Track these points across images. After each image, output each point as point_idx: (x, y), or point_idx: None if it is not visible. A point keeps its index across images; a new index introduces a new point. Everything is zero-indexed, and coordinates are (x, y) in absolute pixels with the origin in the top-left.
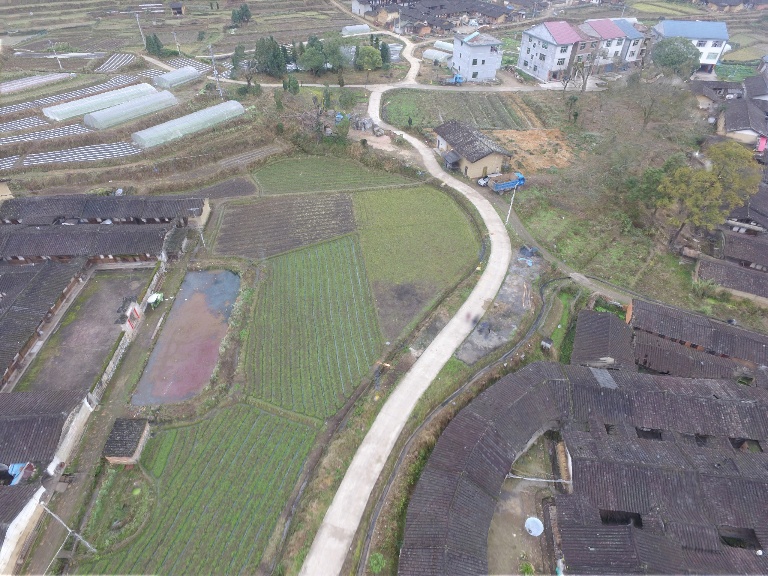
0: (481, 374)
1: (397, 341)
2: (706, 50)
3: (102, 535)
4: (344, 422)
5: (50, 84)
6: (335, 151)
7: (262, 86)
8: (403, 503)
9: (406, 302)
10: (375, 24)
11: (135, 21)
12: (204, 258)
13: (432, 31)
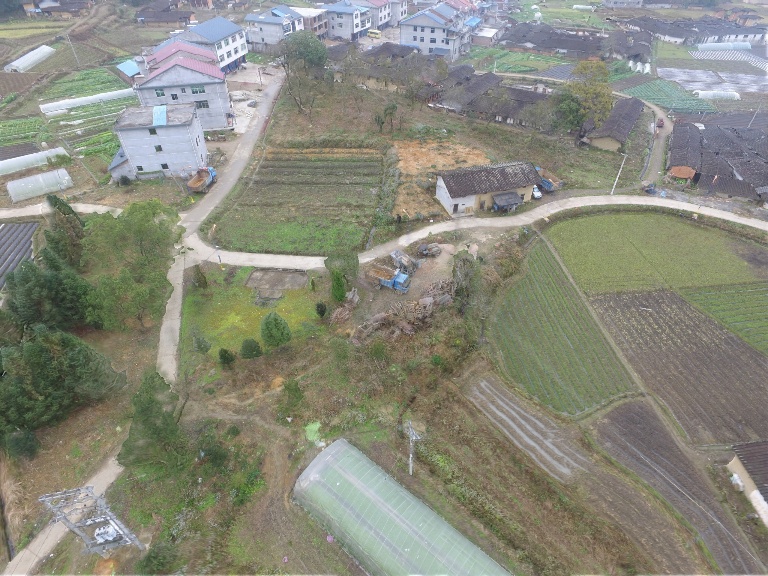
0: None
1: None
2: (237, 44)
3: None
4: None
5: None
6: None
7: None
8: None
9: None
10: None
11: None
12: None
13: None
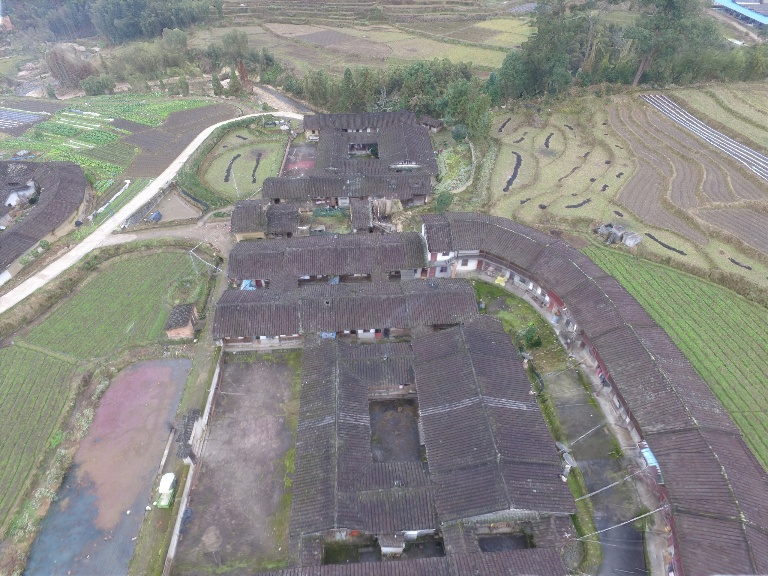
0: None
1: None
2: None
3: (194, 279)
4: None
5: None
6: None
7: None
8: None
9: None
10: None
11: None
12: None
13: None
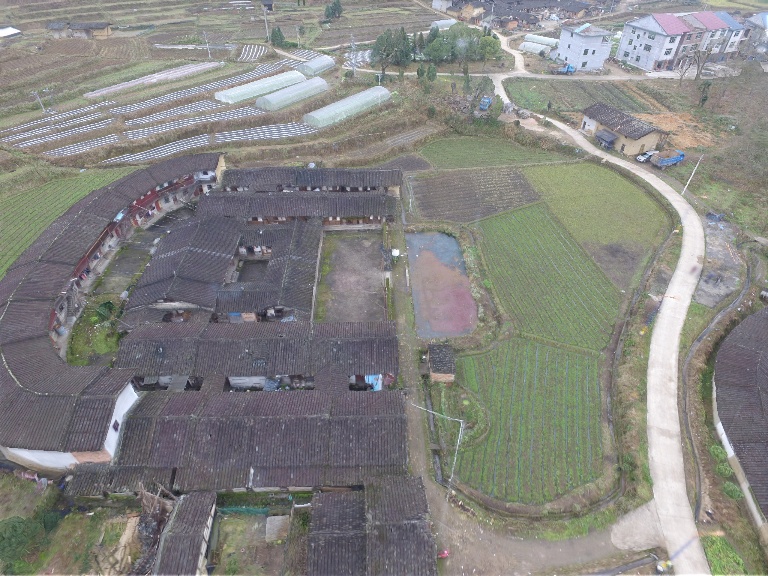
0: (719, 317)
1: (632, 289)
2: None
3: None
4: (618, 352)
5: (207, 71)
6: (487, 132)
7: (393, 74)
8: (705, 414)
9: (621, 258)
10: (460, 19)
11: (232, 17)
12: (415, 222)
13: (518, 25)
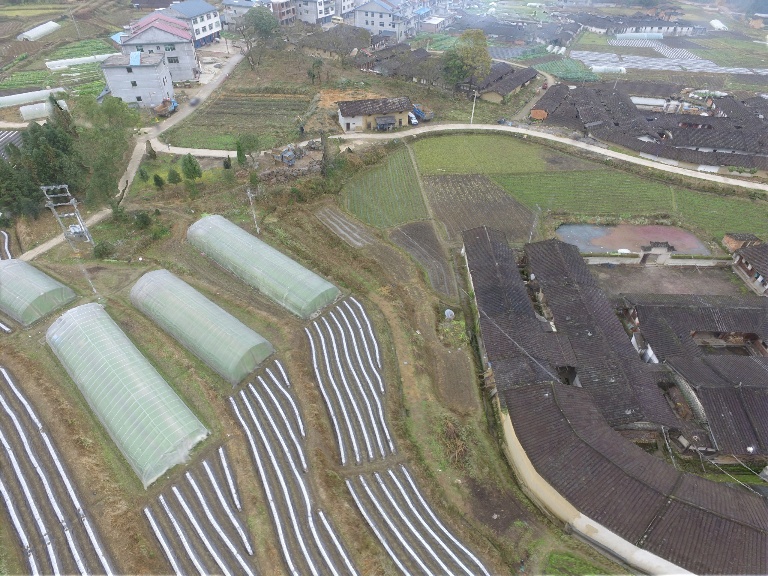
0: None
1: (601, 164)
2: (212, 21)
3: None
4: None
5: None
6: (341, 176)
7: None
8: None
9: (564, 161)
10: None
11: None
12: None
13: None
